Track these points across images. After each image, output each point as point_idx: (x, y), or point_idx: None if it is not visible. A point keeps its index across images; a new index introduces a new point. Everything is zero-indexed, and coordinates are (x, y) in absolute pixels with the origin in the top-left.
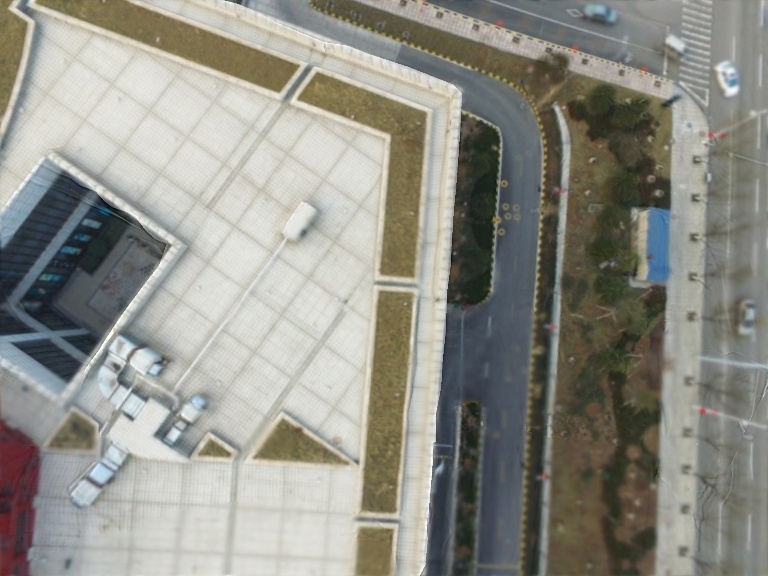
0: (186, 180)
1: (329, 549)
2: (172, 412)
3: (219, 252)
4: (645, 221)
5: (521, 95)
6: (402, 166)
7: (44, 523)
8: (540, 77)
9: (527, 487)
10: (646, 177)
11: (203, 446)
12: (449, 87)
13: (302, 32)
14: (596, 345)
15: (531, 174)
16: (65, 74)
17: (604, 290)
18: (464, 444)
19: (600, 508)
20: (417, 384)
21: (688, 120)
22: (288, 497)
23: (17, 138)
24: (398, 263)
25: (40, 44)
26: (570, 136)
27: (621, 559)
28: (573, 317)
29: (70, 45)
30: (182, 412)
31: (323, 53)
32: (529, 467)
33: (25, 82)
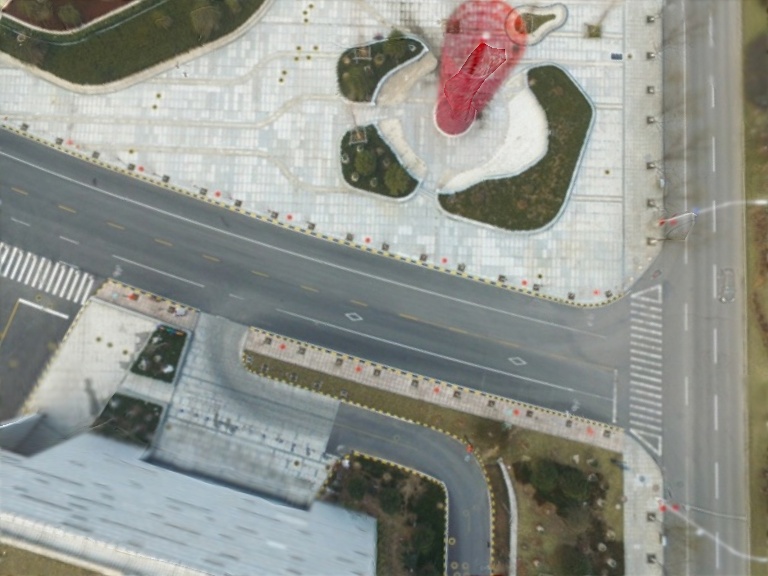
0: None
1: None
2: None
3: None
4: None
5: (466, 447)
6: None
7: None
8: (483, 434)
9: None
10: (597, 545)
11: None
12: None
13: (238, 397)
14: None
15: (479, 529)
16: None
17: None
18: None
19: None
20: None
21: (640, 473)
22: None
23: None
24: None
25: None
26: (516, 500)
27: None
28: None
29: None
30: None
31: None
32: None
33: None
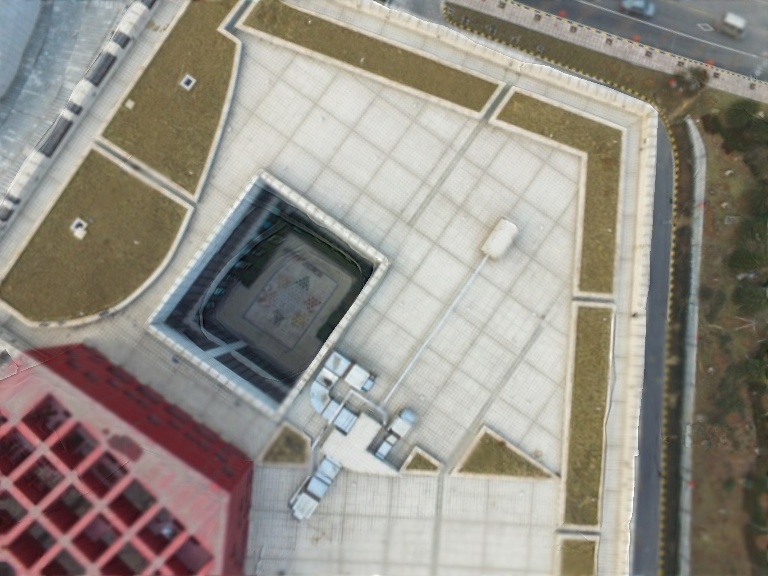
0: (387, 198)
1: (532, 561)
2: (383, 427)
3: (420, 269)
4: None
5: None
6: (599, 184)
7: (271, 537)
8: (673, 91)
9: (665, 496)
10: None
11: (411, 460)
12: (646, 106)
13: None
14: (735, 355)
15: (663, 186)
16: (270, 94)
17: (744, 301)
18: None
19: (742, 517)
20: (615, 398)
21: None
22: (491, 510)
23: (225, 157)
24: (596, 279)
25: (246, 64)
26: (705, 149)
27: (764, 567)
28: (711, 328)
29: (274, 65)
30: (393, 427)
31: (517, 73)
32: (667, 476)
33: (233, 102)
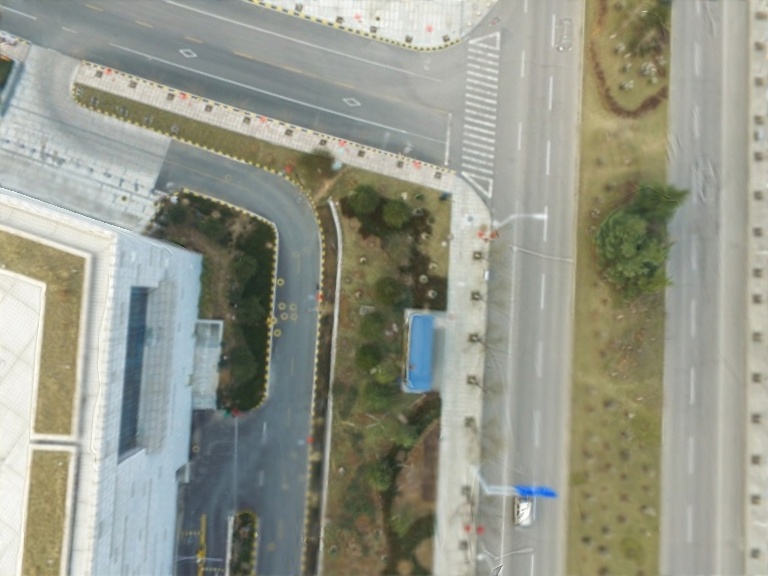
0: None
1: None
2: None
3: None
4: (409, 327)
5: (298, 189)
6: (58, 316)
7: None
8: (313, 171)
9: None
10: (419, 277)
11: None
12: (104, 233)
13: (67, 130)
14: (366, 455)
15: (309, 271)
16: None
17: (371, 398)
18: (235, 557)
19: None
20: (77, 547)
21: (469, 213)
22: None
23: None
24: (53, 420)
25: None
26: (342, 234)
27: None
28: (344, 425)
29: None
30: None
31: None
32: None
33: None
